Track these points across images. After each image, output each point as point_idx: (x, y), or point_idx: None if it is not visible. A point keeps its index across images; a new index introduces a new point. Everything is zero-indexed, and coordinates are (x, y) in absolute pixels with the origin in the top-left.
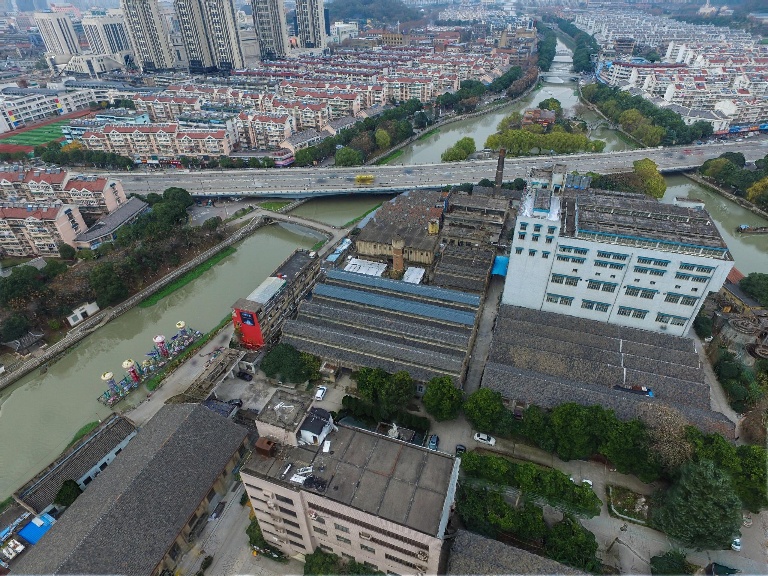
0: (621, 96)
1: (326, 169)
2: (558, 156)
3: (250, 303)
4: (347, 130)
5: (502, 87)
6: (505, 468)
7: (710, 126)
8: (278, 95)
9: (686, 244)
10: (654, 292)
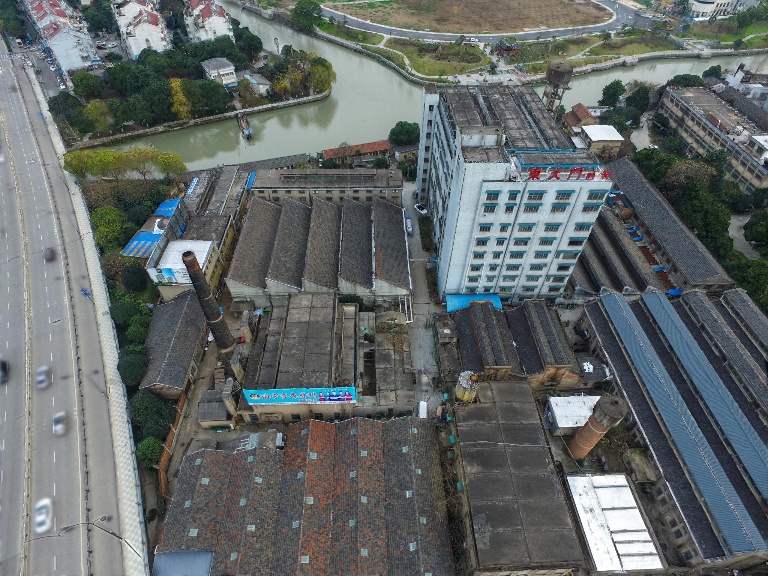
0: None
1: None
2: None
3: None
4: None
5: None
6: None
7: None
8: None
9: None
10: None
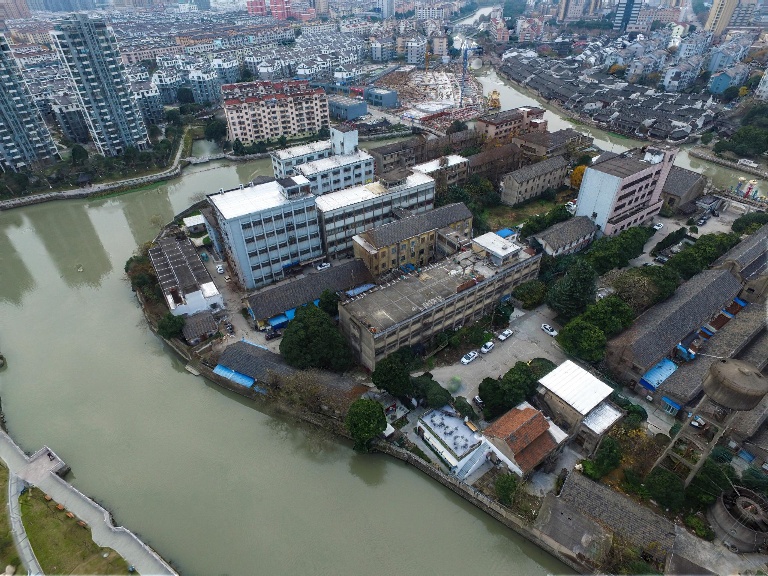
0: None
1: None
2: None
3: None
4: None
5: None
6: (624, 235)
7: None
8: None
9: None
10: None
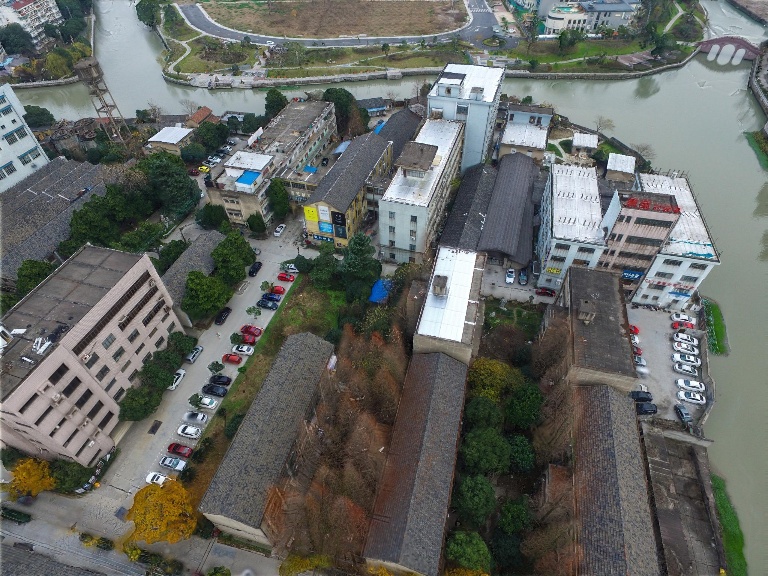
0: None
1: None
2: None
3: None
4: None
5: None
6: None
7: None
8: None
9: None
10: None
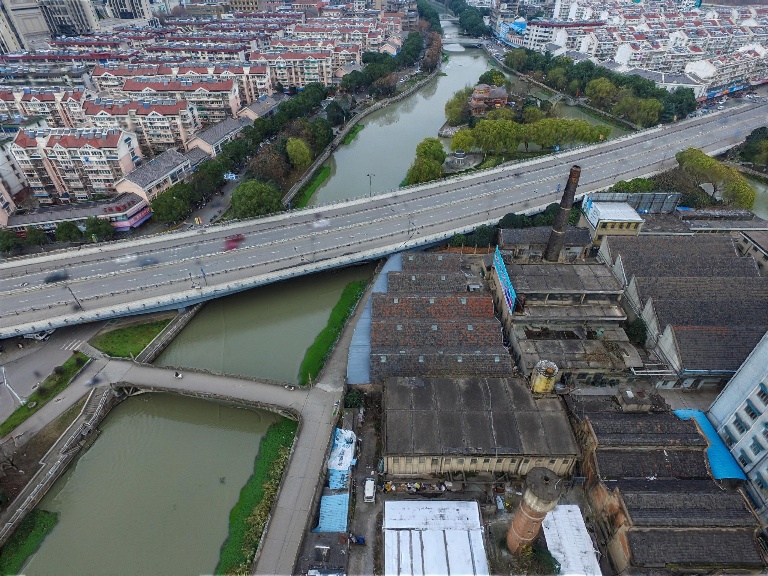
0: (562, 62)
1: (221, 228)
2: (561, 154)
3: None
4: (234, 144)
5: (412, 59)
6: None
7: (693, 93)
8: (91, 92)
9: None
10: None
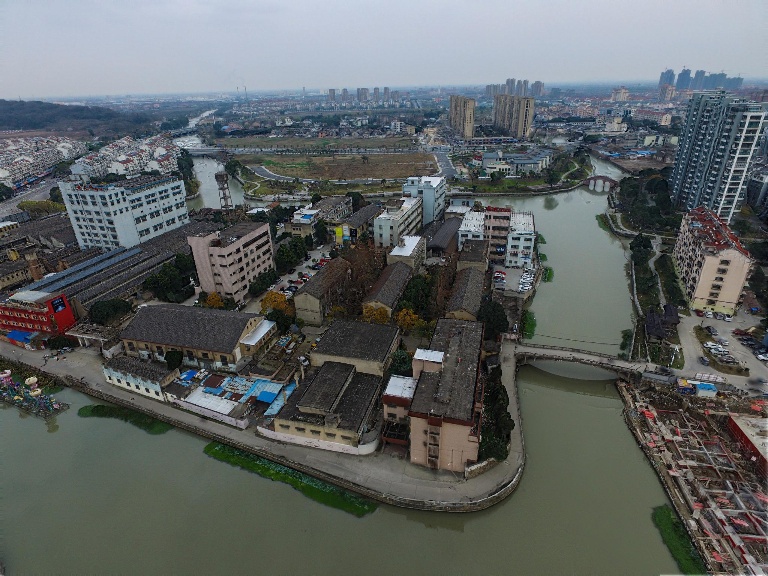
0: None
1: None
2: None
3: (47, 296)
4: None
5: None
6: None
7: None
8: None
9: (166, 179)
10: (171, 207)
